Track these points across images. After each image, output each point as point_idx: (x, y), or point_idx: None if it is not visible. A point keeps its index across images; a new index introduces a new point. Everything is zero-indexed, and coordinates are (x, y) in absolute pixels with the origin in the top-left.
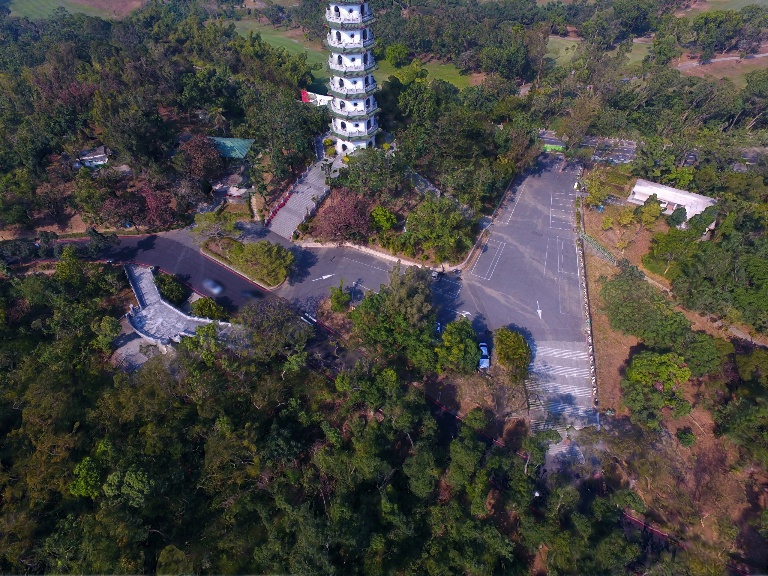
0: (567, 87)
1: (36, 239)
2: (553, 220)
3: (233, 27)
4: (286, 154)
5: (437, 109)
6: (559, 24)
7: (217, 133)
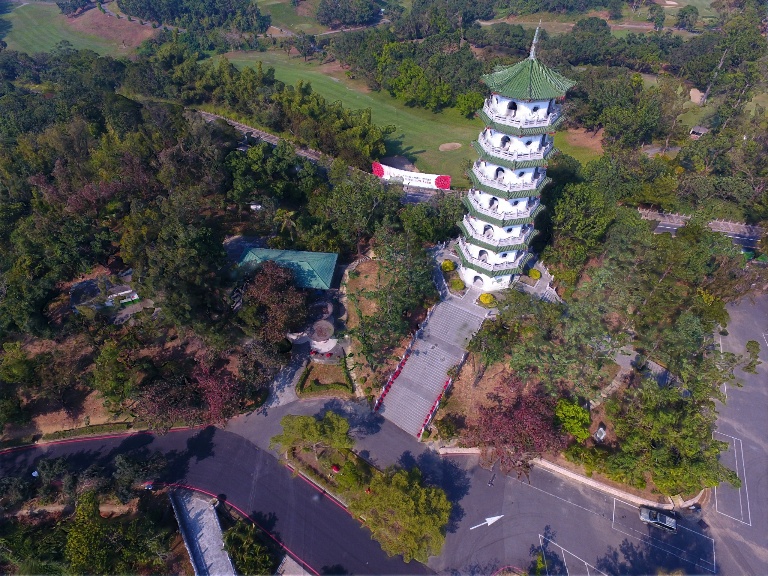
0: (724, 161)
1: (34, 439)
2: None
3: (272, 71)
4: (386, 280)
5: None
6: (653, 62)
7: (283, 243)
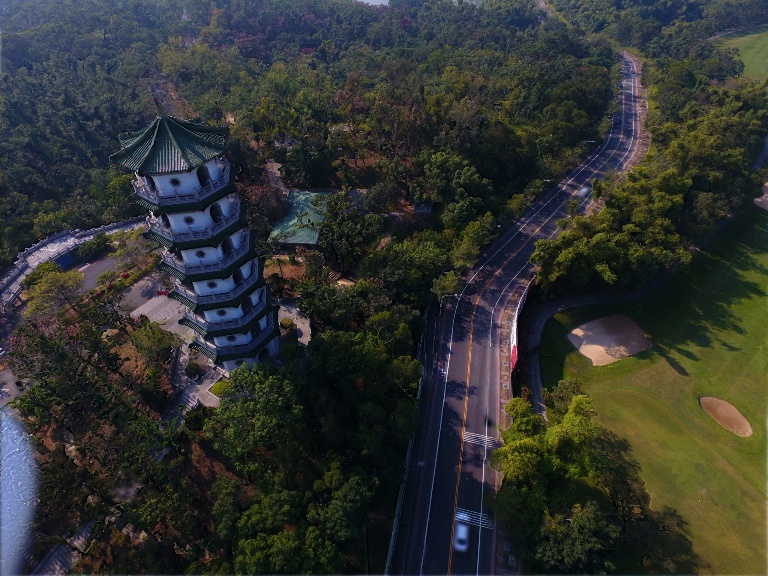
0: None
1: None
2: None
3: (737, 160)
4: None
5: None
6: None
7: None
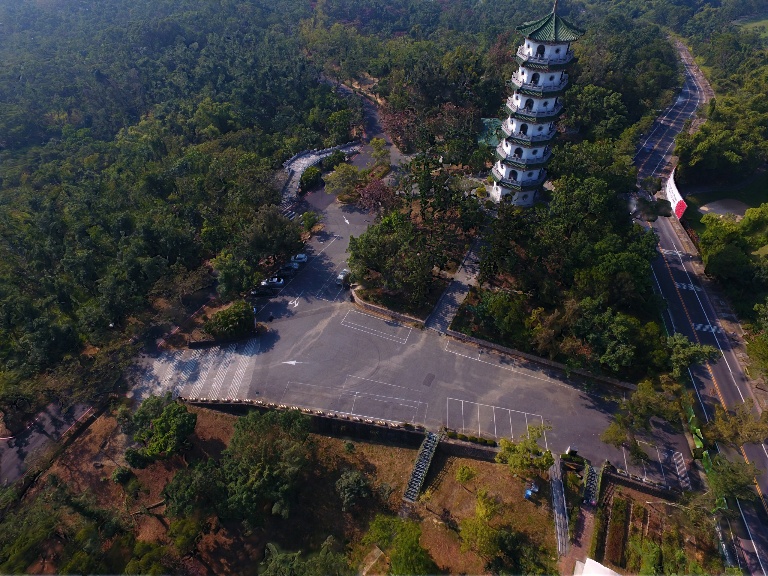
0: None
1: None
2: (465, 404)
3: None
4: None
5: None
6: None
7: None
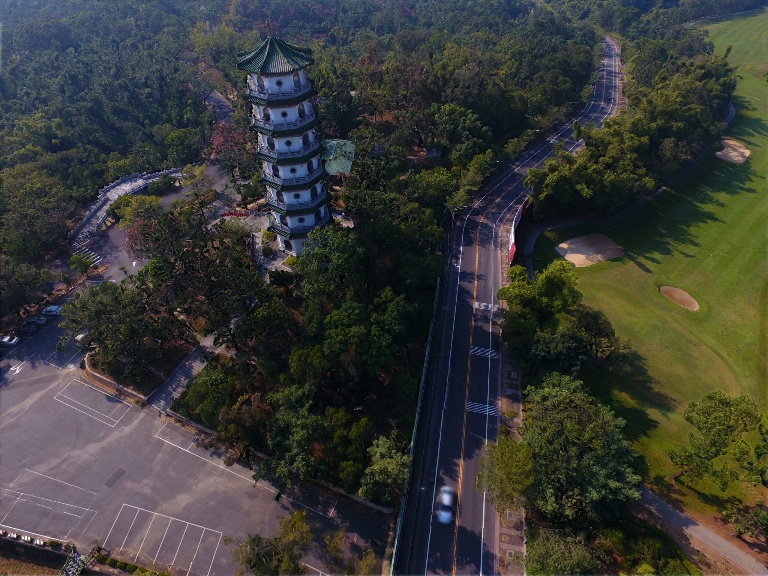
0: None
1: None
2: (140, 514)
3: (696, 113)
4: None
5: (341, 289)
6: None
7: None
